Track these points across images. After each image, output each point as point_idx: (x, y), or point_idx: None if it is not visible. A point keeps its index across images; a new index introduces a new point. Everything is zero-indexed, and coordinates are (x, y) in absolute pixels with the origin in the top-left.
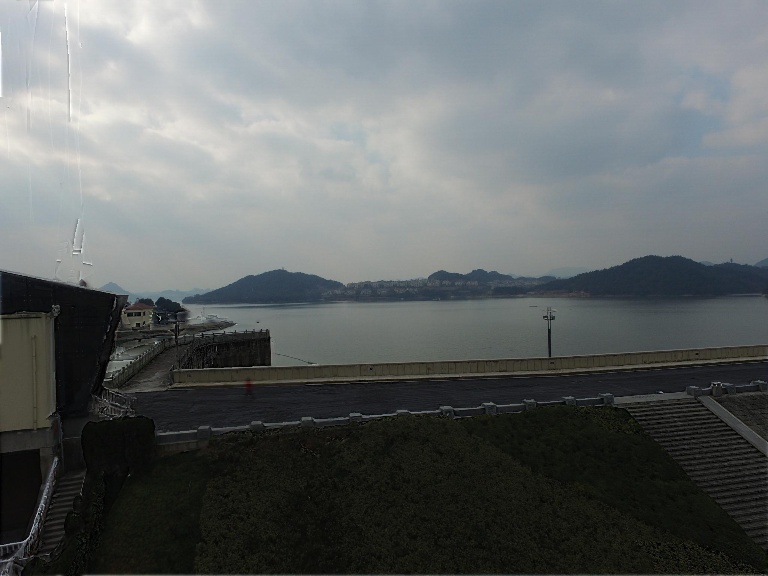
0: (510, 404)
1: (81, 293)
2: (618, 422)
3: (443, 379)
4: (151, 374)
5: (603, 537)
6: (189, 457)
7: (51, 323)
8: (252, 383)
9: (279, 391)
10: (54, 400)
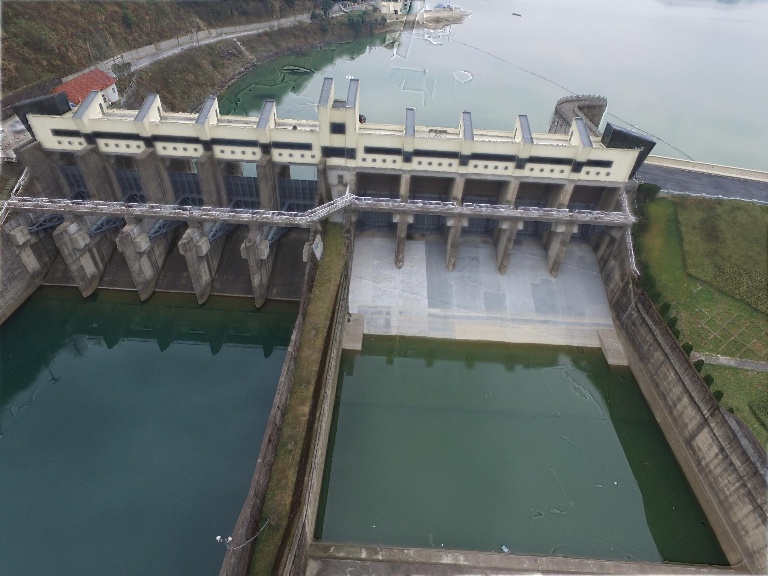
0: None
1: None
2: None
3: (747, 180)
4: None
5: None
6: (667, 199)
7: None
8: (657, 164)
9: (672, 172)
10: None
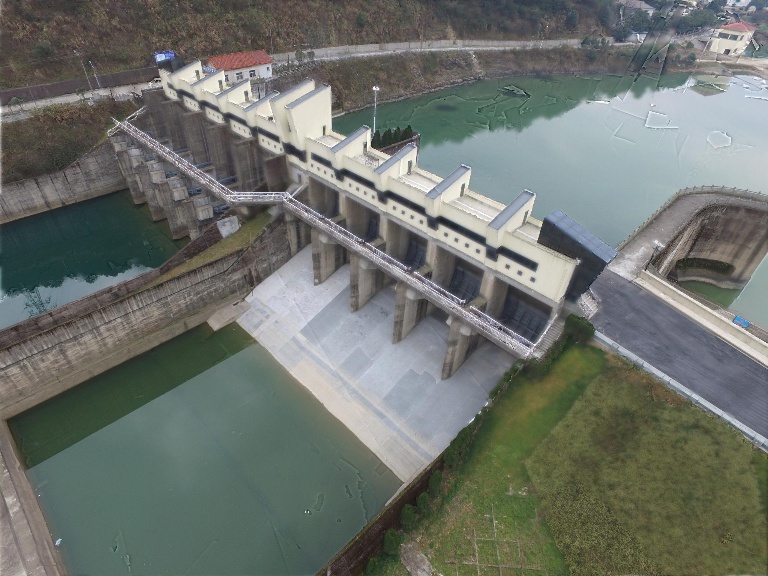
0: None
1: (593, 255)
2: None
3: None
4: (638, 248)
5: (752, 560)
6: (601, 355)
7: (575, 264)
8: (682, 310)
9: (690, 331)
10: (565, 292)
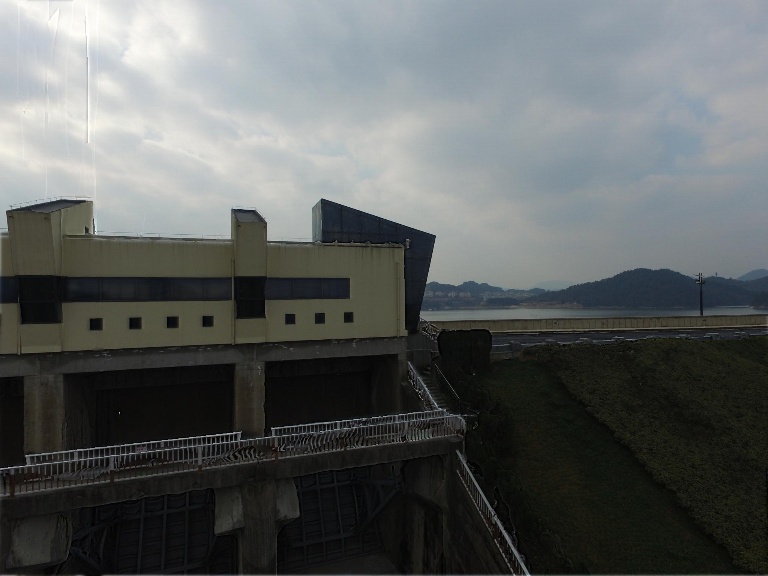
0: None
1: (413, 233)
2: None
3: (620, 331)
4: None
5: None
6: (517, 361)
7: None
8: None
9: (496, 336)
10: None
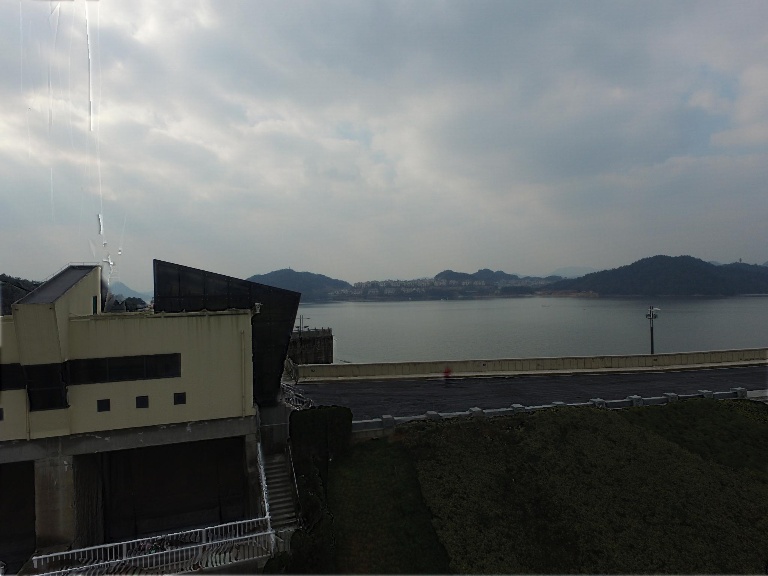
0: (652, 397)
1: (272, 292)
2: (762, 414)
3: (555, 375)
4: None
5: None
6: (383, 443)
7: None
8: (375, 378)
9: (408, 385)
10: None
